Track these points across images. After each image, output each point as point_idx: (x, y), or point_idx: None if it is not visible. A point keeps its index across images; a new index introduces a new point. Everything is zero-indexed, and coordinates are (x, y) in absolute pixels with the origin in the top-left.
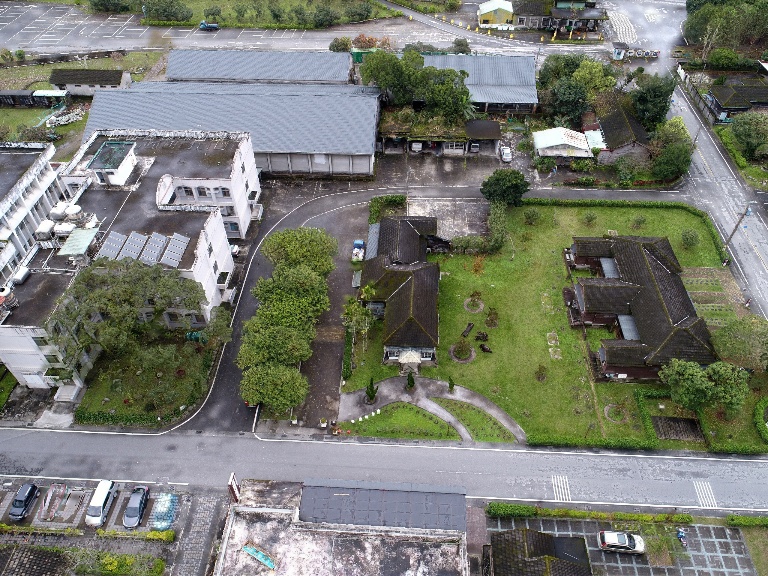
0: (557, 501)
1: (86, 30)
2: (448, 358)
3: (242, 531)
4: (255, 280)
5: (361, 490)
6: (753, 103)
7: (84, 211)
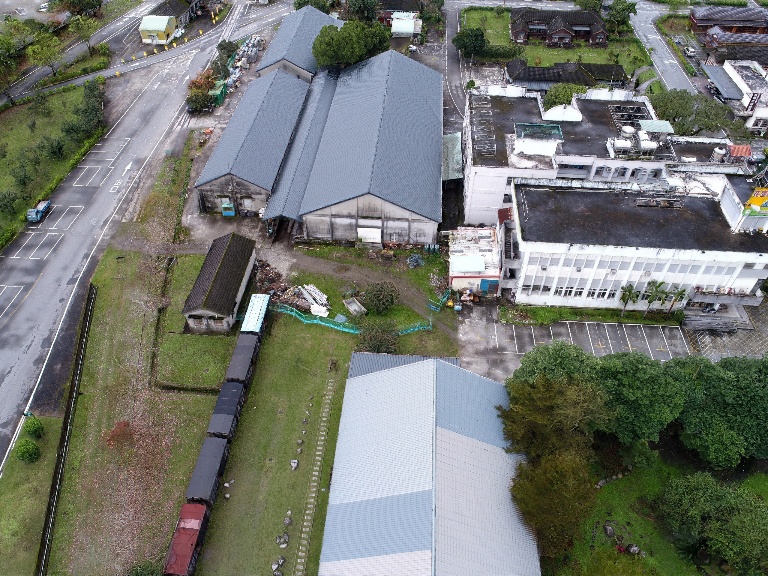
0: None
1: None
2: None
3: None
4: None
5: (720, 85)
6: None
7: (596, 154)
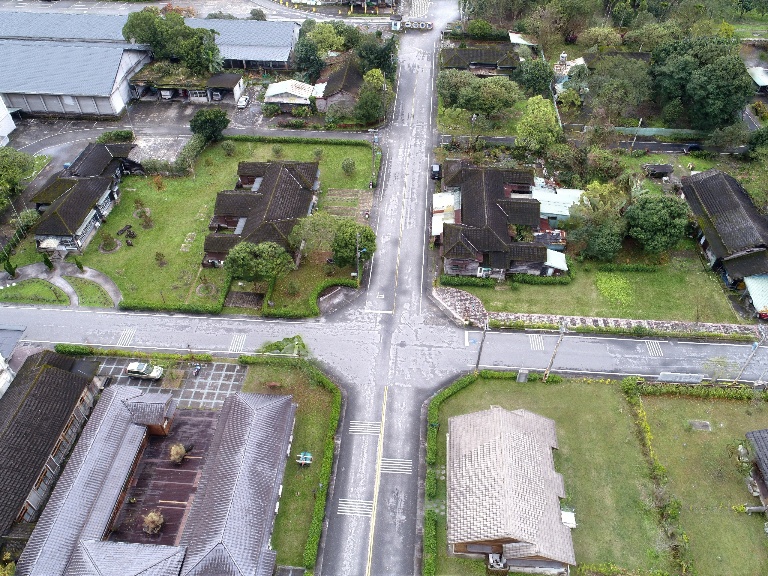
0: (117, 346)
1: None
2: (95, 249)
3: None
4: None
5: None
6: (475, 64)
7: None
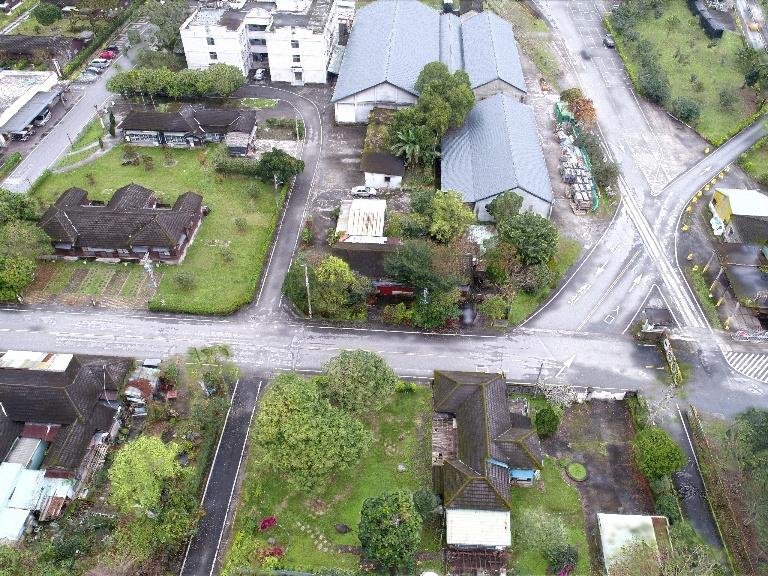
0: (7, 179)
1: (580, 1)
2: None
3: (44, 78)
4: None
5: None
6: None
7: (253, 4)
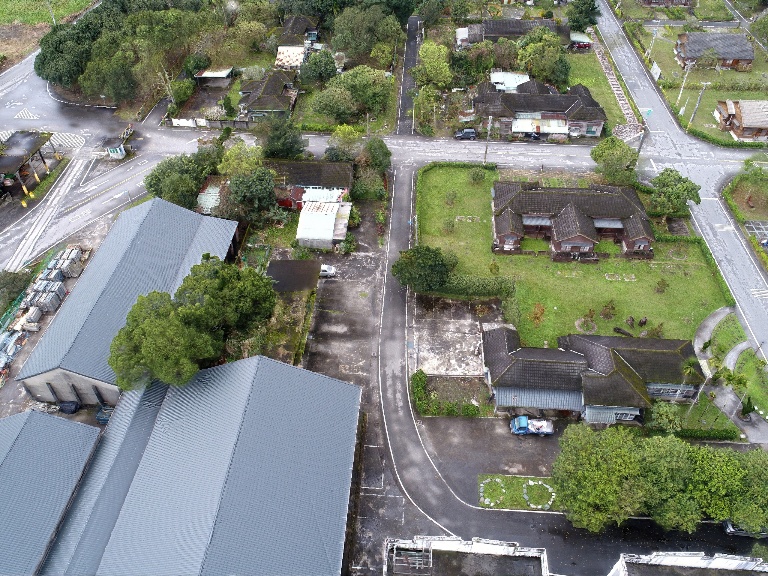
0: None
1: None
2: None
3: None
4: (609, 564)
5: None
6: None
7: None
